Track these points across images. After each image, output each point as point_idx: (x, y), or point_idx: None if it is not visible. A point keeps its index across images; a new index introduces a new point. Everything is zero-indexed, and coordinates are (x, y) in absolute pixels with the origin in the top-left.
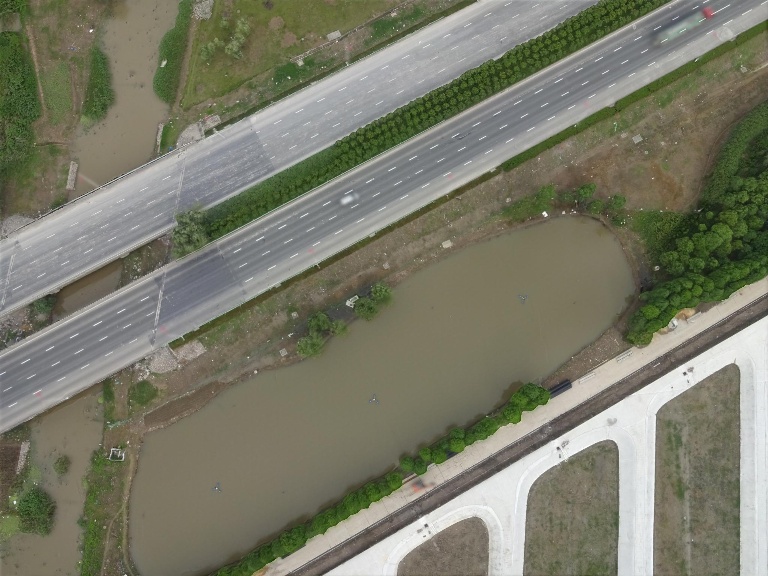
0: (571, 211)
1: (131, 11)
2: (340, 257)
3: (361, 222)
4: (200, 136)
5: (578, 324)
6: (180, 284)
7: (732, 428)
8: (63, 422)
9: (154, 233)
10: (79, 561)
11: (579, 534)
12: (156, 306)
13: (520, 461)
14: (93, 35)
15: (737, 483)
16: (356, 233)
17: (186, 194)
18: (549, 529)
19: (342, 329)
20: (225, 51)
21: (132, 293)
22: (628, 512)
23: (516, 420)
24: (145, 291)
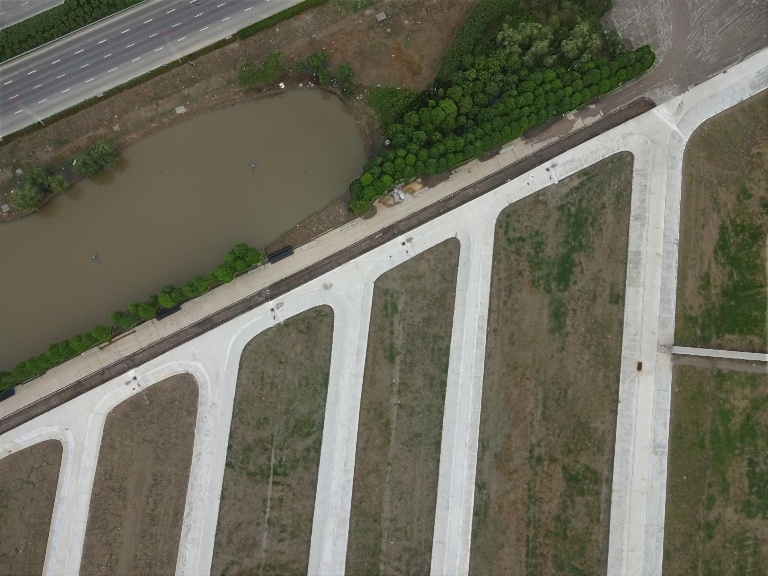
0: (309, 84)
1: None
2: (65, 115)
3: (90, 82)
4: None
5: (305, 193)
6: None
7: (447, 298)
8: None
9: None
10: None
11: (289, 392)
12: None
13: (233, 320)
14: None
15: (447, 350)
16: (84, 93)
17: None
18: (260, 387)
19: (68, 188)
20: None
21: None
22: (337, 373)
23: (223, 277)
24: None
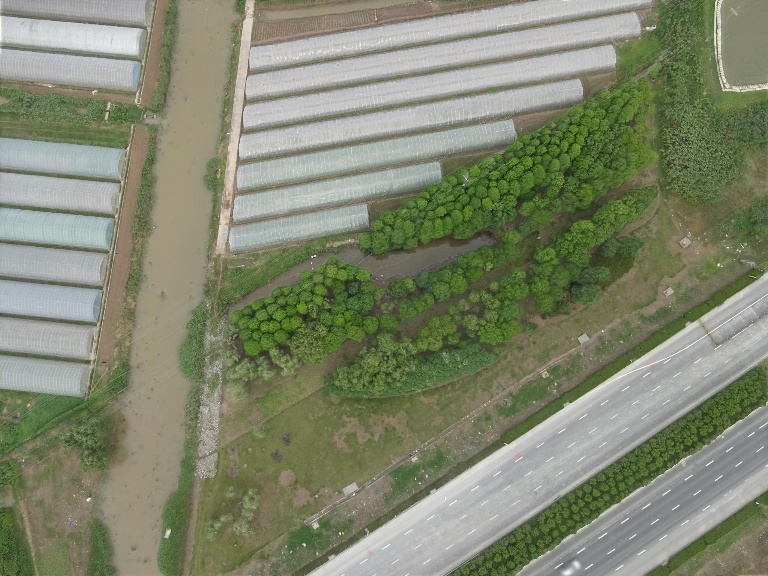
0: None
1: (130, 472)
2: None
3: None
4: None
5: None
6: None
7: None
8: None
9: None
10: None
11: None
12: None
13: None
14: (91, 504)
15: None
16: None
17: None
18: None
19: None
20: (233, 529)
21: None
22: None
23: None
24: None
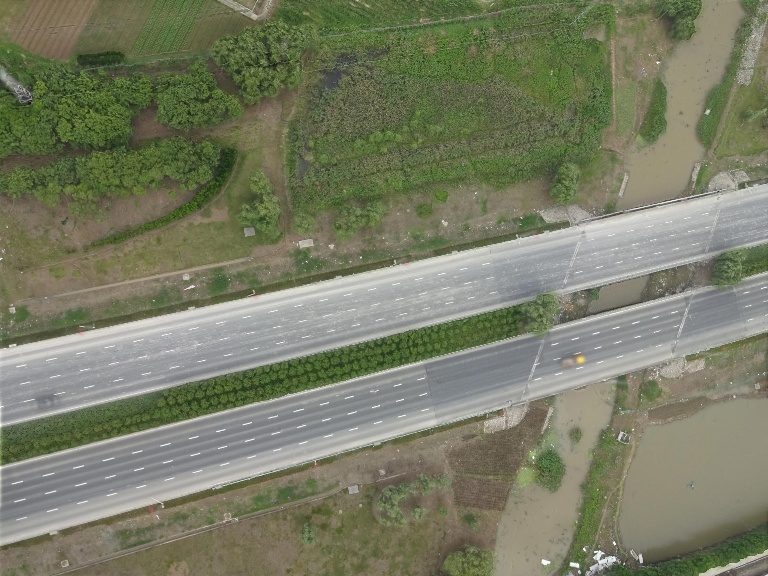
0: None
1: (690, 56)
2: None
3: None
4: (735, 186)
5: None
6: (702, 308)
7: None
8: (581, 398)
9: (690, 258)
10: (576, 521)
11: None
12: (681, 321)
13: None
14: (658, 67)
15: None
16: None
17: (718, 233)
18: None
19: None
20: None
21: (666, 304)
22: None
23: None
24: (676, 306)
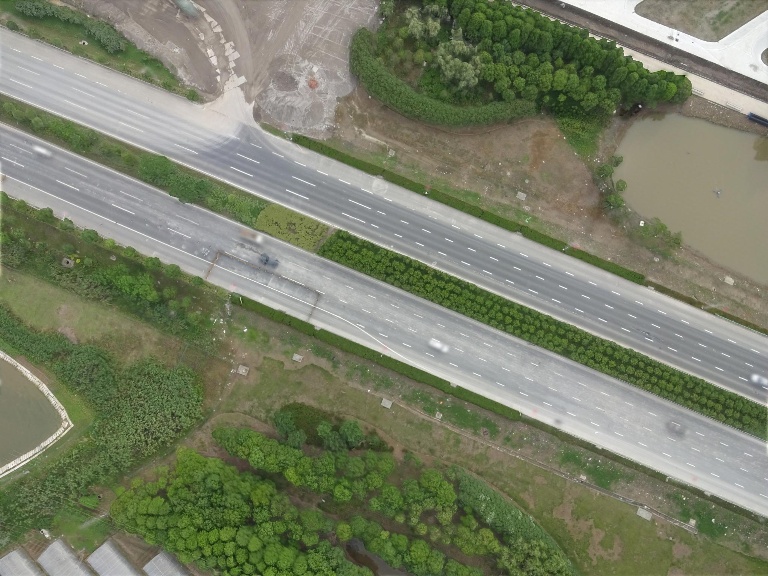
0: None
1: None
2: None
3: None
4: None
5: (702, 140)
6: None
7: None
8: None
9: None
10: None
11: None
12: None
13: None
14: None
15: None
16: None
17: None
18: None
19: None
20: None
21: None
22: None
23: None
24: None
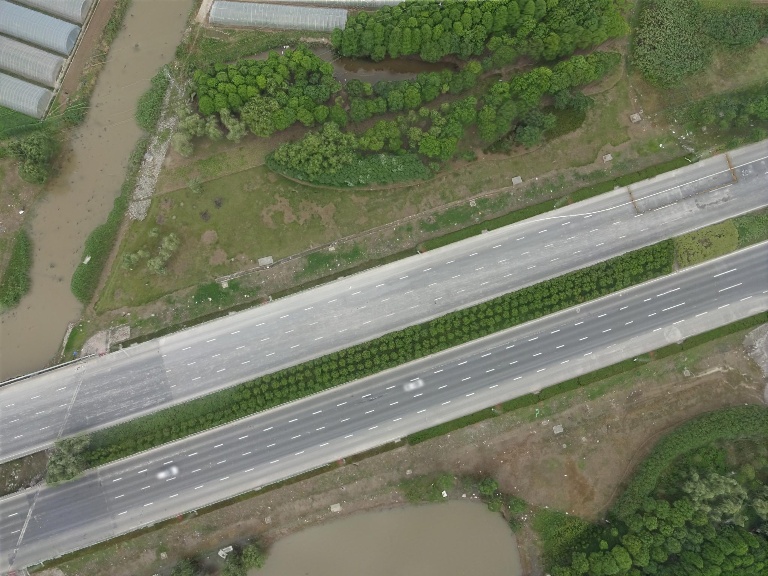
0: (472, 495)
1: (66, 197)
2: (220, 506)
3: (250, 472)
4: (104, 350)
5: None
6: (51, 505)
7: None
8: None
9: (36, 446)
10: None
11: None
12: (23, 524)
13: None
14: (22, 217)
15: None
16: (242, 483)
17: (77, 410)
18: None
19: None
20: (147, 265)
21: (1, 506)
22: None
23: None
24: (15, 507)
